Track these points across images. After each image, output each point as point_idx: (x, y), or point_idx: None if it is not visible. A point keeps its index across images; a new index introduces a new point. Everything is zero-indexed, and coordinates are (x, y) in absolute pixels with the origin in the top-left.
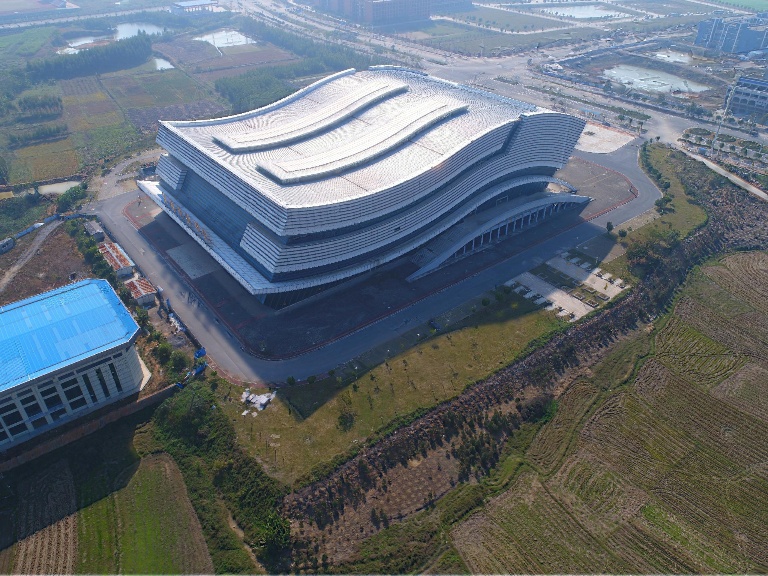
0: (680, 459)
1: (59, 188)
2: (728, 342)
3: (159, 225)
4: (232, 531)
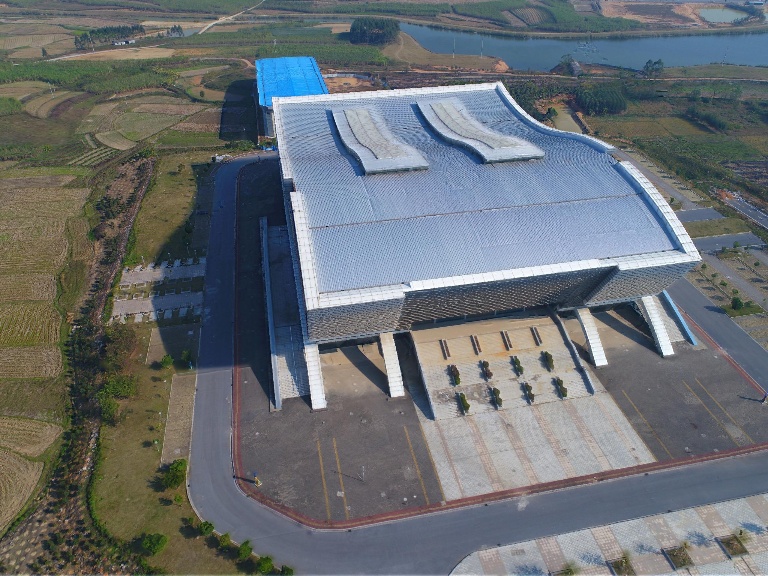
0: (2, 261)
1: (569, 130)
2: None
3: None
4: None
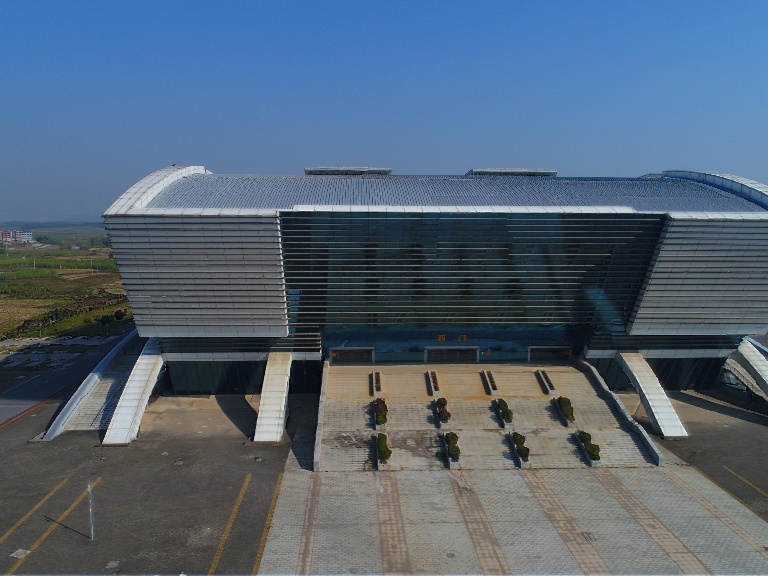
0: None
1: None
2: None
3: None
4: None
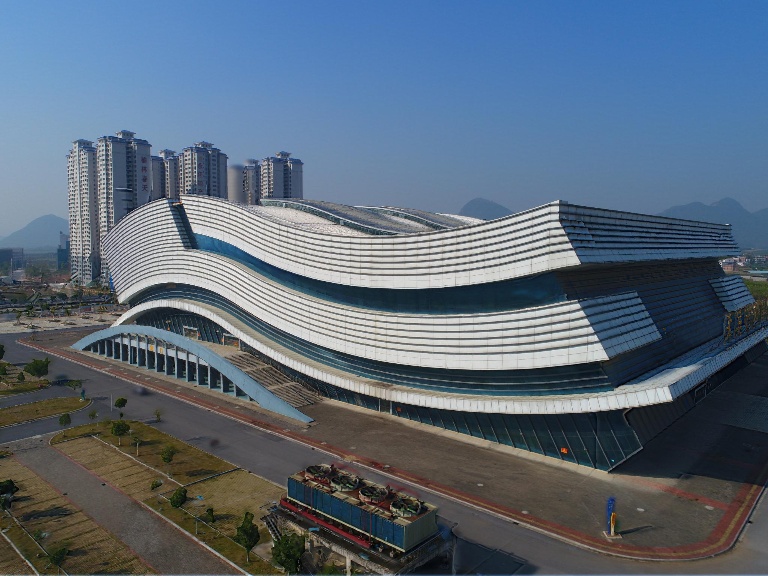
0: None
1: None
2: None
3: (701, 461)
4: None
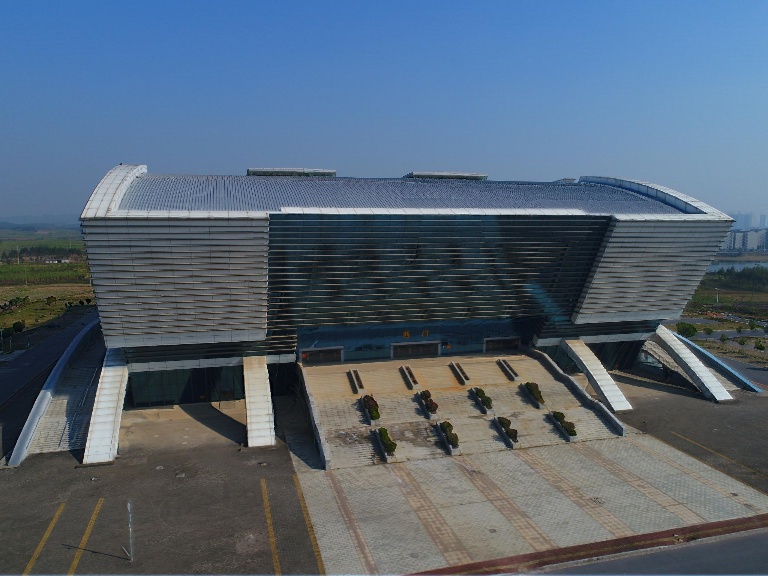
0: None
1: None
2: None
3: None
4: None
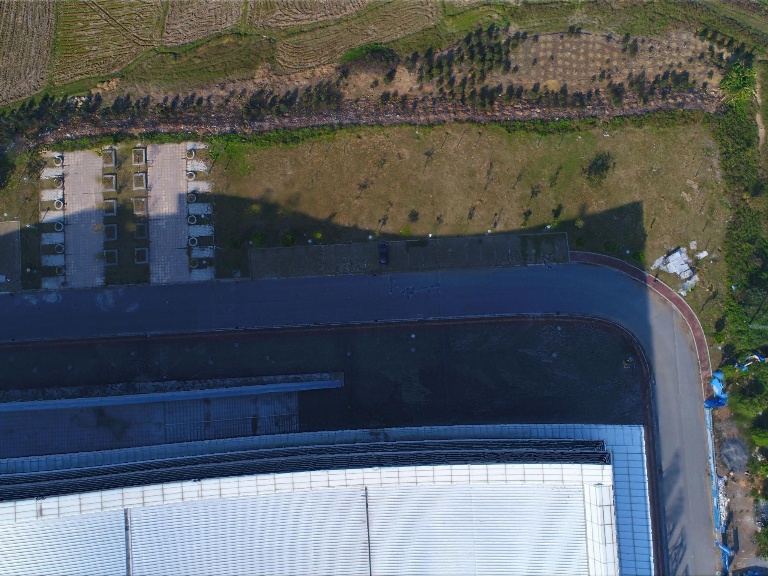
0: None
1: None
2: (43, 6)
3: None
4: (767, 124)
